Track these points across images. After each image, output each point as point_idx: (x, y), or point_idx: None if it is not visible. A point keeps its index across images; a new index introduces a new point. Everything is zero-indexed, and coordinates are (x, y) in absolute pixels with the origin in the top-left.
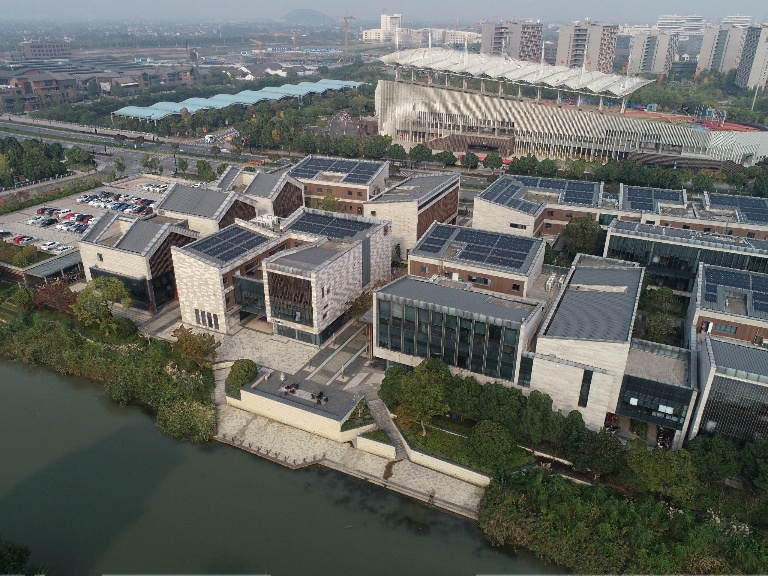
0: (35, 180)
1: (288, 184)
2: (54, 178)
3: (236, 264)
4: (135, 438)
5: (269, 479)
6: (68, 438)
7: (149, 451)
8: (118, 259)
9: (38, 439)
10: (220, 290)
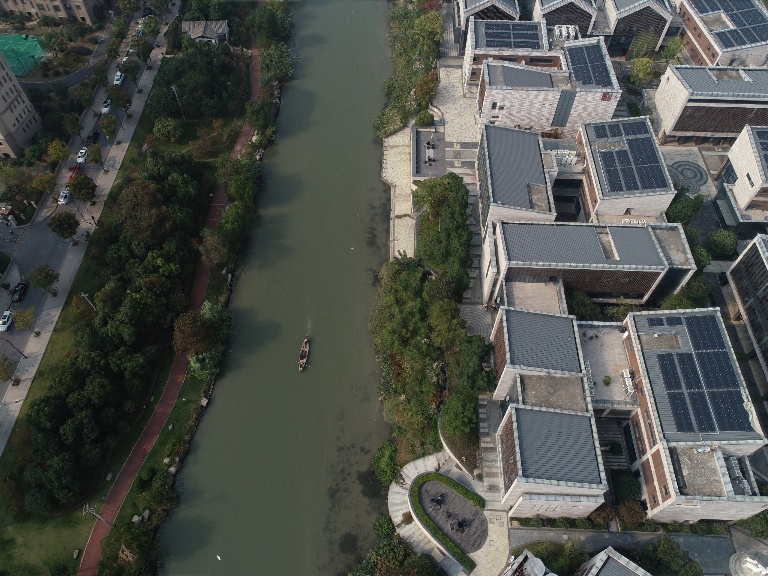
0: None
1: (649, 9)
2: None
3: (491, 52)
4: (365, 112)
5: (370, 173)
6: (351, 91)
7: (359, 122)
8: None
9: (345, 82)
10: (469, 63)
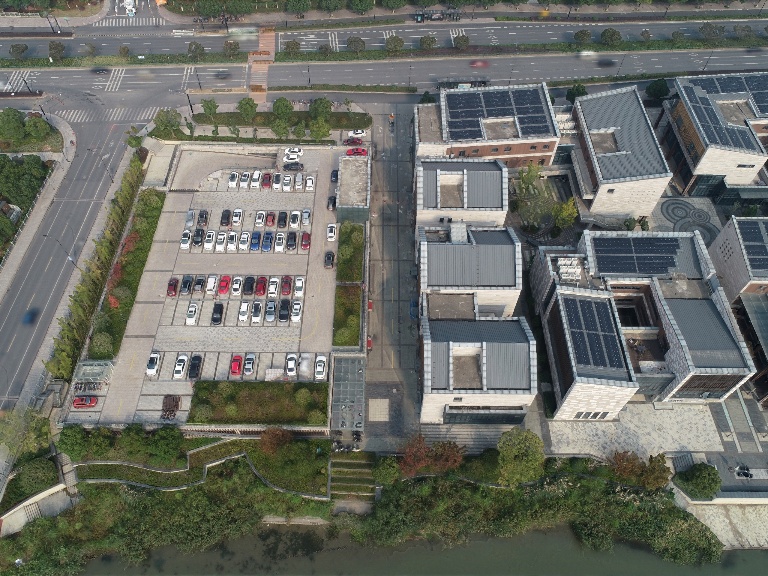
0: (30, 205)
1: None
2: (42, 186)
3: None
4: None
5: None
6: None
7: None
8: (489, 398)
9: None
10: None
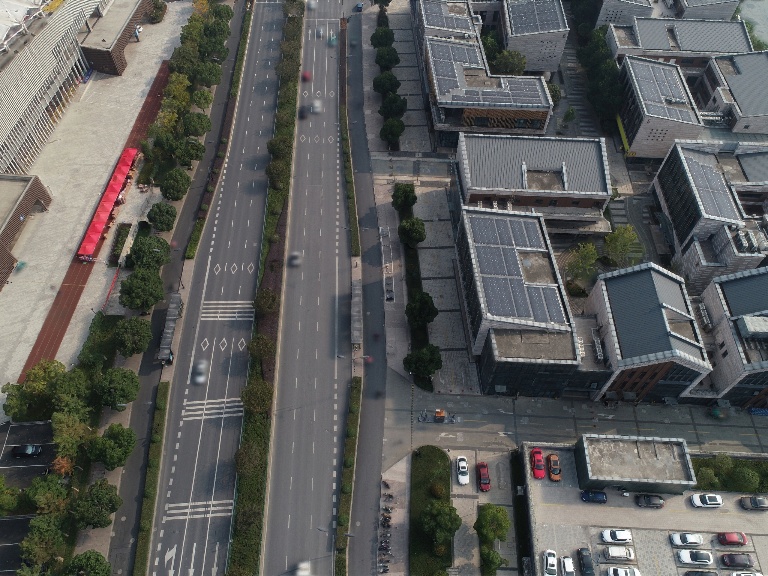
0: None
1: None
2: None
3: None
4: None
5: None
6: None
7: None
8: None
9: None
10: None
